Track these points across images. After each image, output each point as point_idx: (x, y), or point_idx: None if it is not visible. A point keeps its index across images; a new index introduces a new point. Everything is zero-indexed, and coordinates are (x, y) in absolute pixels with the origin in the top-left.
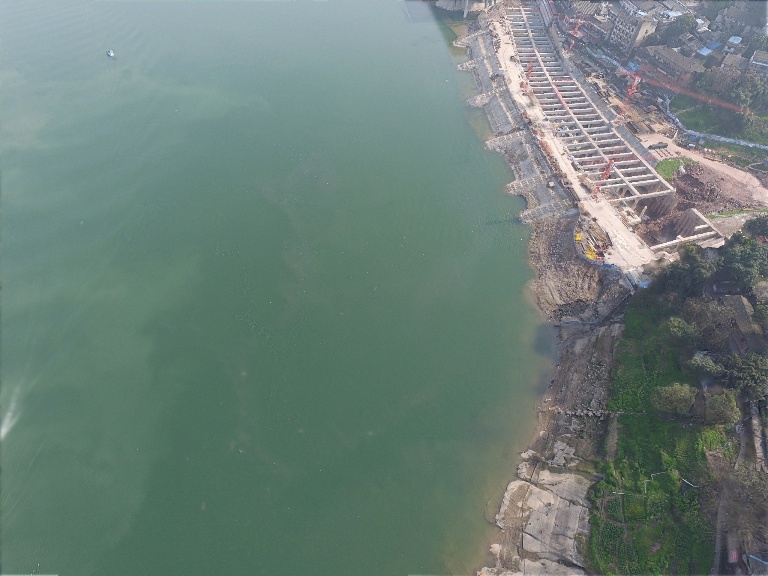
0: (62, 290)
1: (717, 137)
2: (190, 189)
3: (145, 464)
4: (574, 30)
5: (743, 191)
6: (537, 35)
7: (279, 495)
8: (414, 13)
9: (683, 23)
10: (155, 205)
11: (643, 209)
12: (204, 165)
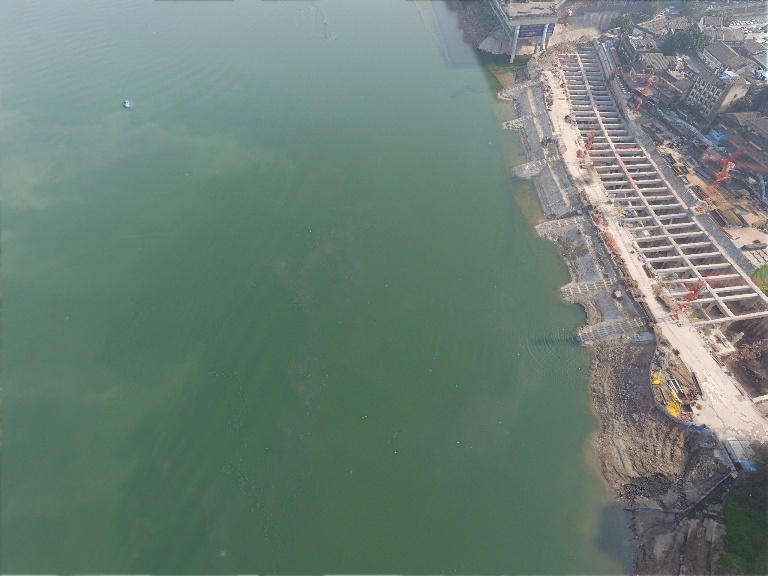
0: (33, 410)
1: None
2: (189, 281)
3: None
4: (643, 89)
5: None
6: (596, 88)
7: None
8: (455, 57)
9: None
10: (147, 303)
11: (738, 335)
12: (208, 250)
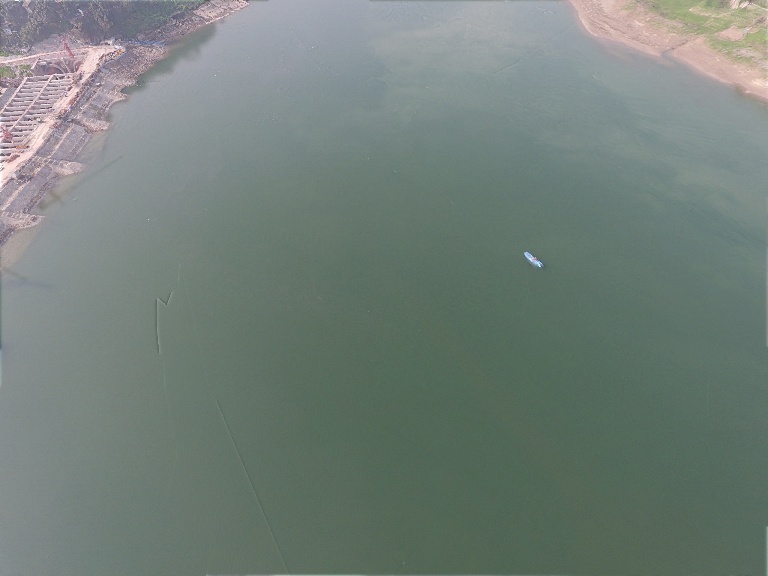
0: (418, 64)
1: None
2: (353, 93)
3: (346, 19)
4: None
5: None
6: None
7: (299, 18)
8: None
9: None
10: None
11: None
12: (346, 105)
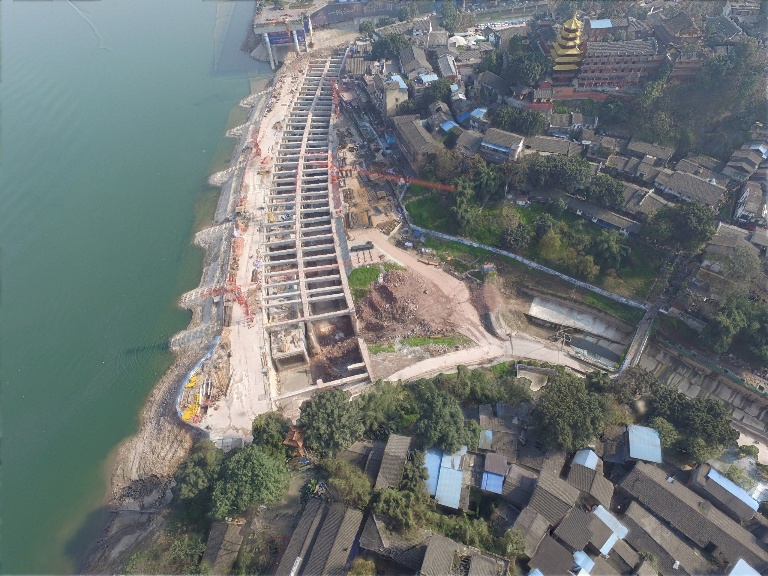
0: None
1: (439, 234)
2: None
3: None
4: None
5: (442, 309)
6: (326, 93)
7: None
8: (223, 65)
9: (435, 90)
10: None
11: (309, 335)
12: None
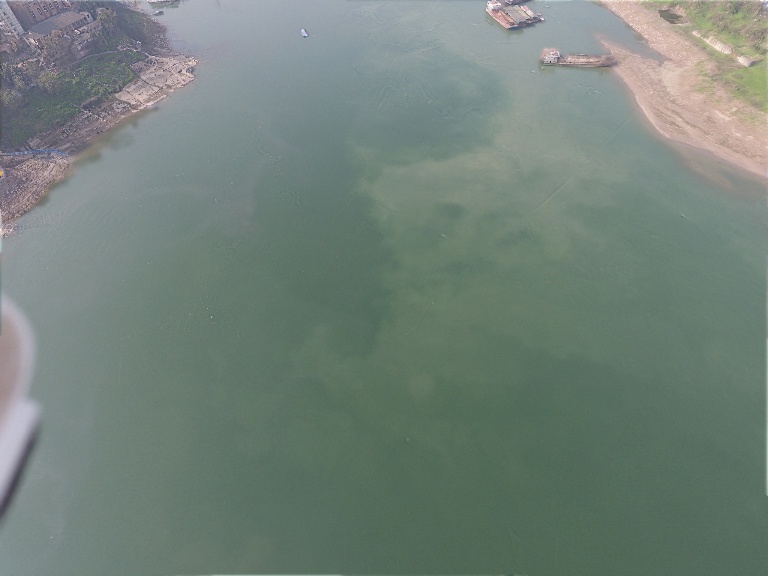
0: (426, 186)
1: None
2: (336, 256)
3: (324, 106)
4: None
5: None
6: None
7: (260, 102)
8: None
9: None
10: (364, 229)
11: None
12: (325, 286)
